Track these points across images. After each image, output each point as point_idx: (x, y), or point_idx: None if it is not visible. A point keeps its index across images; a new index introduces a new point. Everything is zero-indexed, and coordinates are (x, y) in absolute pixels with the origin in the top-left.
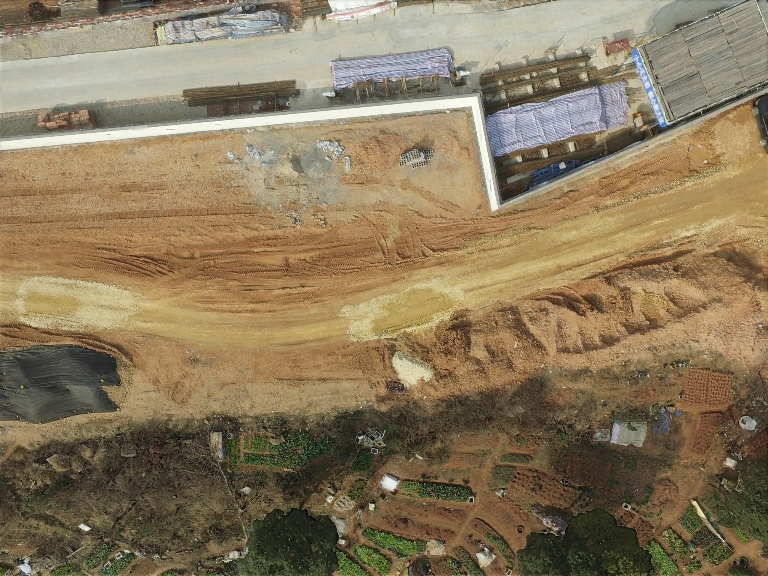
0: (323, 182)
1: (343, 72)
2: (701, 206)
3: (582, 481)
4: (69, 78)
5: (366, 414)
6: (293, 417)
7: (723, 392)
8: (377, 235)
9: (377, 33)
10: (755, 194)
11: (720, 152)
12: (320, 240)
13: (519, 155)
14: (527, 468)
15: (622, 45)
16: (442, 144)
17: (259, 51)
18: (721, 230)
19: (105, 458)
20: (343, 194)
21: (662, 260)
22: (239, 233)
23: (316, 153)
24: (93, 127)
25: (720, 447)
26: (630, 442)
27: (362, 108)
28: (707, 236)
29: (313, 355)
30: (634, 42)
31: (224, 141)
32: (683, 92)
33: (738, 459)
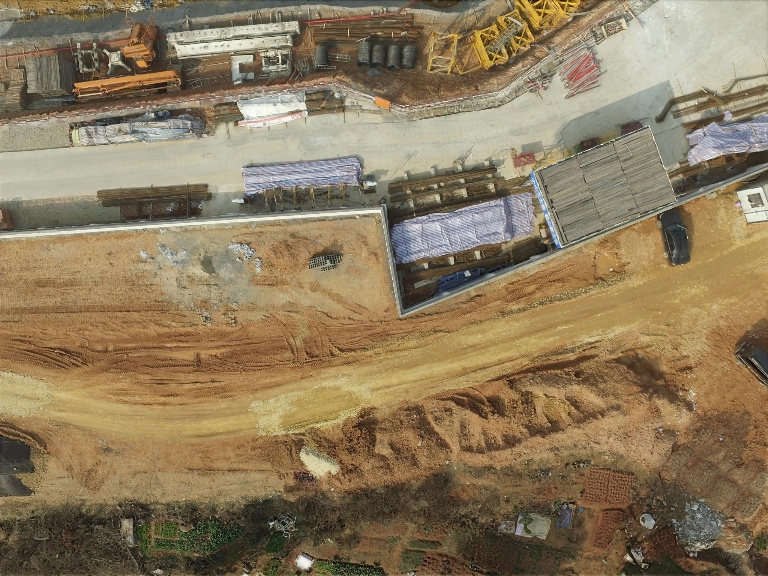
0: (234, 282)
1: (253, 179)
2: (605, 314)
3: (489, 568)
4: None
5: (276, 503)
6: (204, 505)
7: (623, 492)
8: (286, 334)
9: (288, 140)
10: (658, 303)
11: (625, 261)
12: (231, 337)
13: (425, 262)
14: (437, 553)
15: (527, 159)
16: (351, 249)
17: (172, 155)
18: (624, 337)
19: (20, 539)
20: (253, 294)
21: (566, 364)
22: (151, 329)
23: (227, 254)
24: (7, 226)
25: (621, 543)
26: (534, 534)
27: (269, 217)
28: (610, 342)
29: (223, 447)
30: (542, 154)
31: (138, 240)
32: (577, 217)
33: (638, 555)
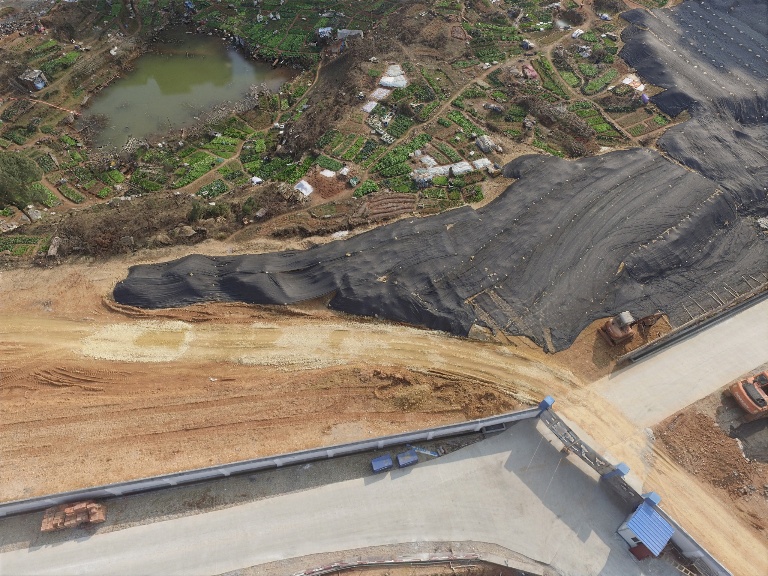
0: None
1: None
2: None
3: None
4: (65, 575)
5: None
6: None
7: None
8: None
9: None
10: None
11: None
12: None
13: None
14: None
15: None
16: None
17: None
18: None
19: None
20: None
21: None
22: None
23: None
24: None
25: None
26: None
27: None
28: None
29: None
30: None
31: None
32: None
33: None
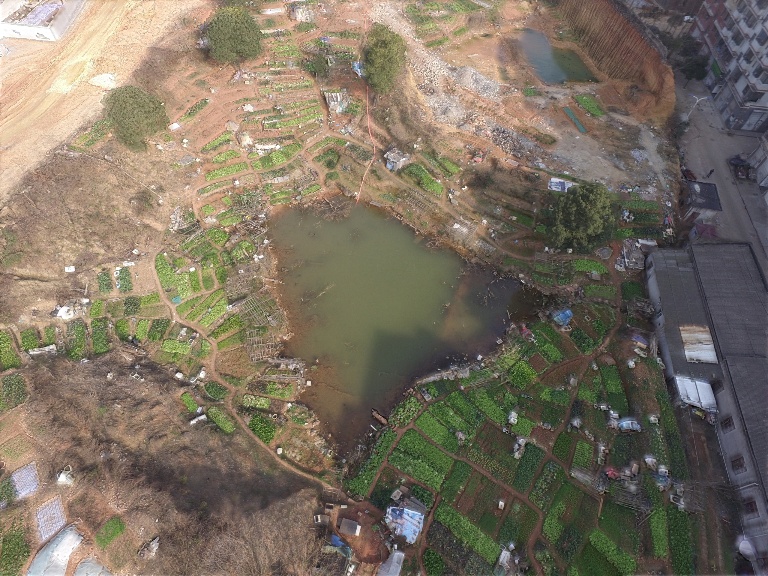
0: None
1: None
2: None
3: None
4: None
5: None
6: (83, 125)
7: None
8: None
9: None
10: None
11: None
12: (3, 90)
13: None
14: None
15: None
16: (8, 45)
17: None
18: None
19: (19, 207)
20: None
21: None
22: None
23: None
24: None
25: None
26: None
27: None
28: (134, 1)
29: (57, 107)
30: None
31: None
32: None
33: None
